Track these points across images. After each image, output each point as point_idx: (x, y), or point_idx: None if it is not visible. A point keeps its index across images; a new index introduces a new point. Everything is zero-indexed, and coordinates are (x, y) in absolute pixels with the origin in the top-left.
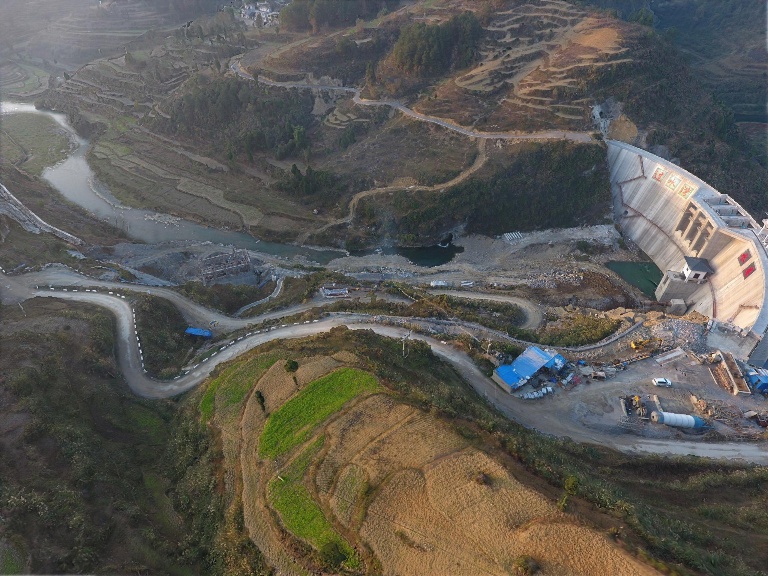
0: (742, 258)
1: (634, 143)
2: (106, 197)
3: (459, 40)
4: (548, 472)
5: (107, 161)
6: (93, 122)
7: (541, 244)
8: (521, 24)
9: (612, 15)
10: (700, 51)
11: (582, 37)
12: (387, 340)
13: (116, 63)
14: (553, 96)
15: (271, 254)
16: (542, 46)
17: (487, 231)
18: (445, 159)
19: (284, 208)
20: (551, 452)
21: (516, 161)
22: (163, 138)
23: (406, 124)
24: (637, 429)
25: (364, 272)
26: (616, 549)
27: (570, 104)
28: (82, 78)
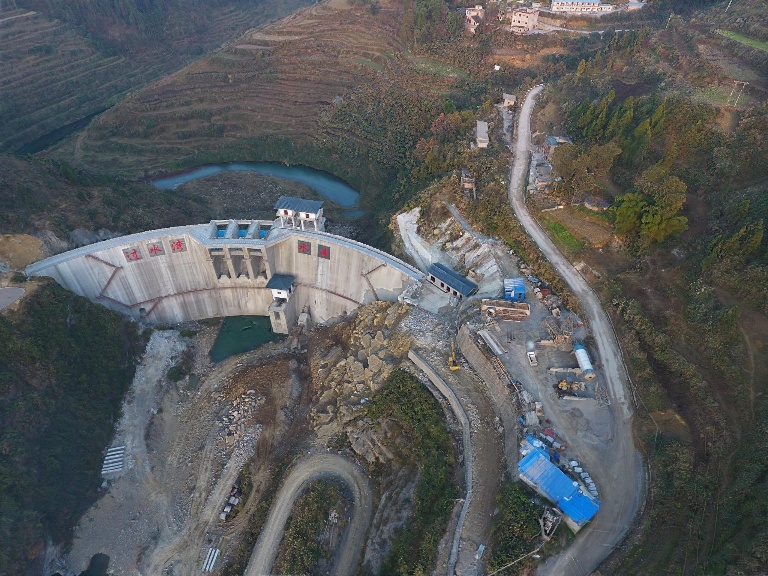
0: (303, 249)
1: (50, 251)
2: None
3: None
4: None
5: None
6: None
7: (151, 424)
8: None
9: None
10: None
11: None
12: None
13: None
14: None
15: None
16: None
17: (82, 501)
18: None
19: None
20: None
21: None
22: None
23: None
24: None
25: None
26: None
27: None
28: None
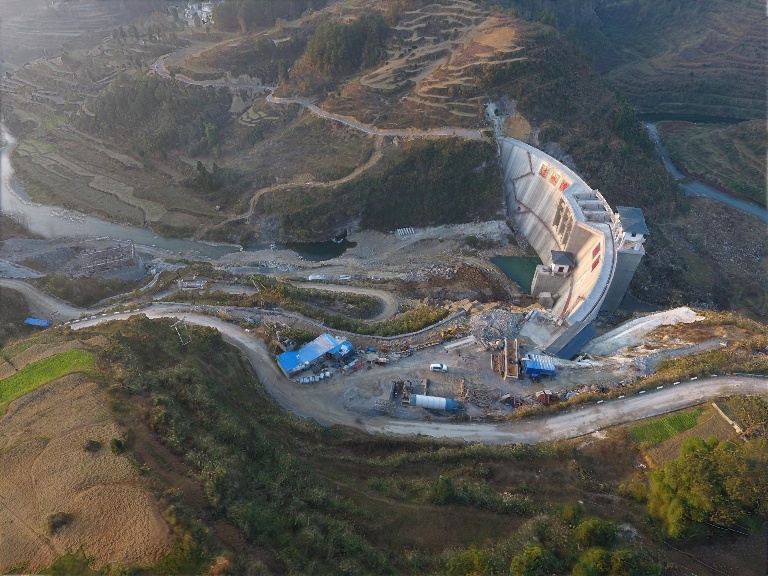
0: (595, 251)
1: (528, 140)
2: (19, 194)
3: (367, 39)
4: (171, 442)
5: (28, 159)
6: (24, 120)
7: (431, 239)
8: (427, 23)
9: (513, 14)
10: (641, 51)
11: (483, 36)
12: (177, 327)
13: (54, 62)
14: (449, 94)
15: (166, 249)
16: (447, 45)
17: (381, 227)
18: (343, 156)
19: (188, 204)
20: (225, 427)
21: (408, 158)
22: (87, 136)
23: (310, 122)
24: (391, 411)
25: (245, 266)
26: (150, 506)
27: (465, 102)
28: (20, 77)
